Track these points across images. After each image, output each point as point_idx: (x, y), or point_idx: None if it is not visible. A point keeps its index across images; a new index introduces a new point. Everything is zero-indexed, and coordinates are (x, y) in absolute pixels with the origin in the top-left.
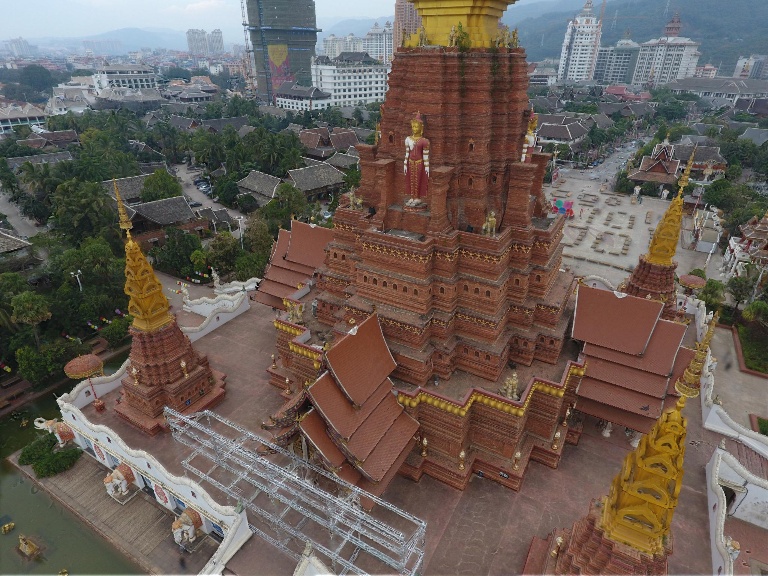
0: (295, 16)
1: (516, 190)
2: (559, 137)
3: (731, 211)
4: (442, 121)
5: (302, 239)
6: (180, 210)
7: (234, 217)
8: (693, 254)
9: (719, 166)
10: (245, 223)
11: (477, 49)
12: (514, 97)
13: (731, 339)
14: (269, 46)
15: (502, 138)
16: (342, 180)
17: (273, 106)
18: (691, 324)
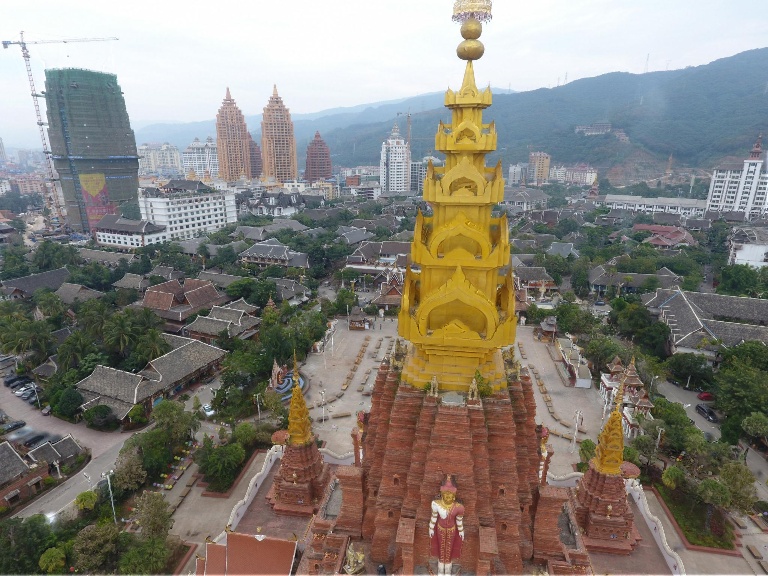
0: (111, 145)
1: (544, 515)
2: (416, 267)
3: (580, 335)
4: (473, 478)
5: (245, 556)
6: (3, 465)
7: (80, 438)
8: (576, 392)
9: (549, 283)
10: (114, 472)
11: (499, 395)
12: (529, 422)
13: (658, 504)
14: (81, 175)
15: (526, 469)
16: (217, 358)
17: (98, 250)
18: (635, 509)
